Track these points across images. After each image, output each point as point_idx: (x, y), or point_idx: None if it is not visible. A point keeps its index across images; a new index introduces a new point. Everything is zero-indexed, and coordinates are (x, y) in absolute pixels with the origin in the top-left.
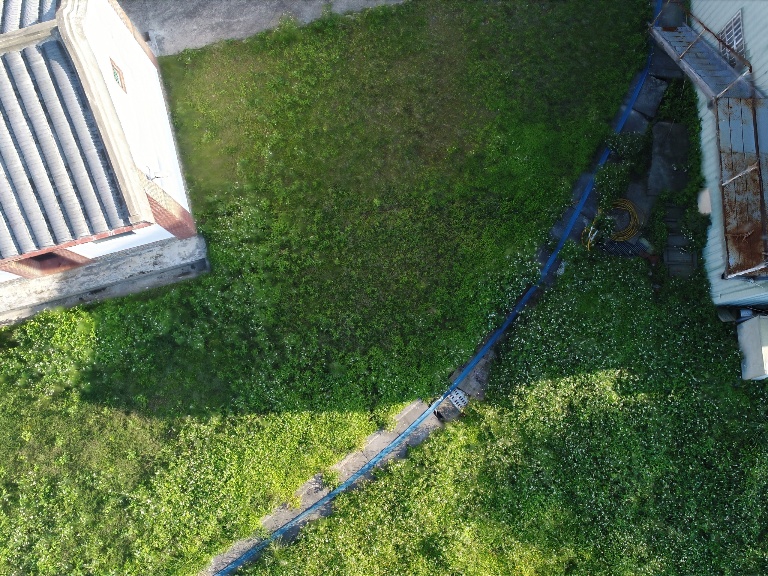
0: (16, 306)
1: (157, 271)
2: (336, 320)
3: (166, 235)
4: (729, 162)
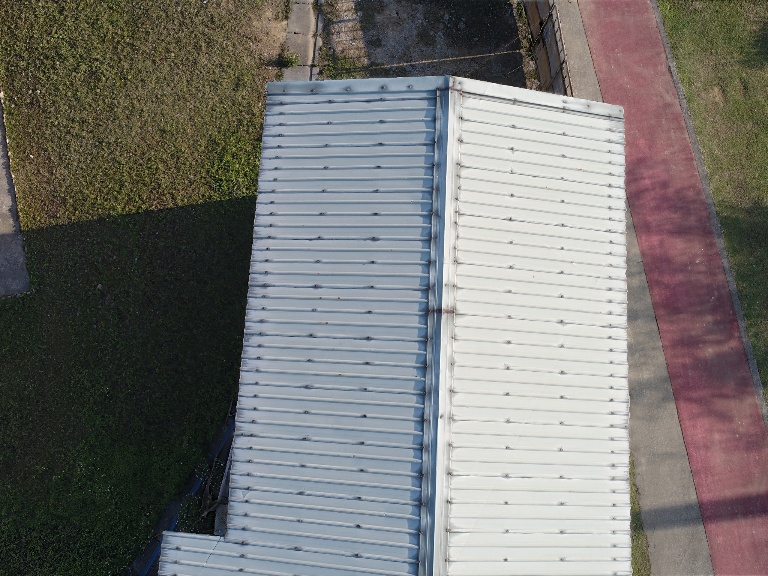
0: None
1: None
2: None
3: None
4: None
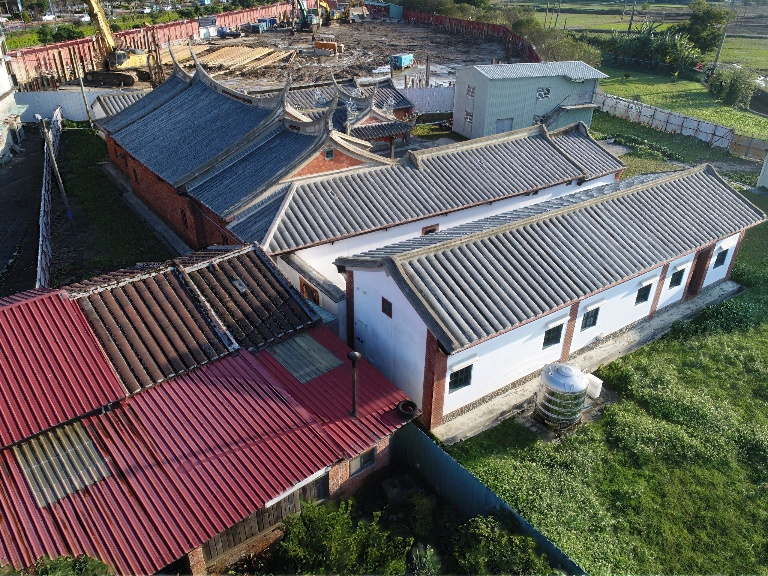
0: (685, 314)
1: (726, 295)
2: None
3: (725, 273)
4: None
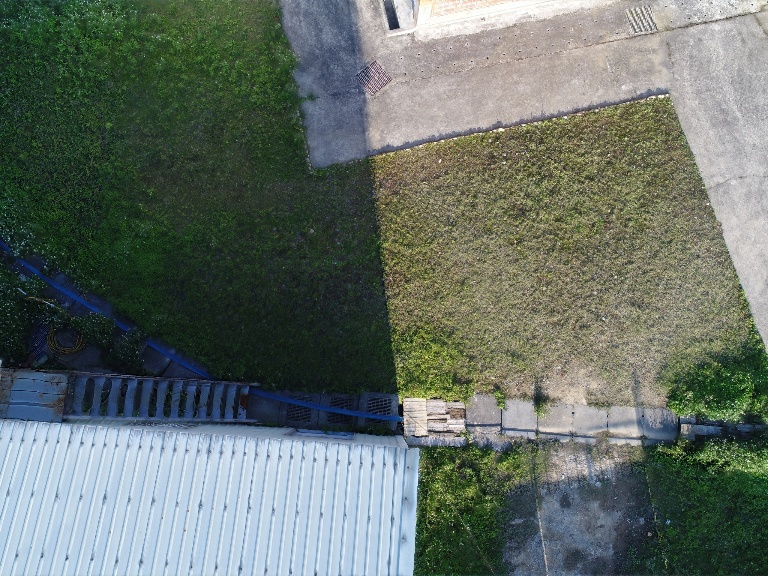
0: None
1: None
2: (5, 86)
3: None
4: (4, 375)
